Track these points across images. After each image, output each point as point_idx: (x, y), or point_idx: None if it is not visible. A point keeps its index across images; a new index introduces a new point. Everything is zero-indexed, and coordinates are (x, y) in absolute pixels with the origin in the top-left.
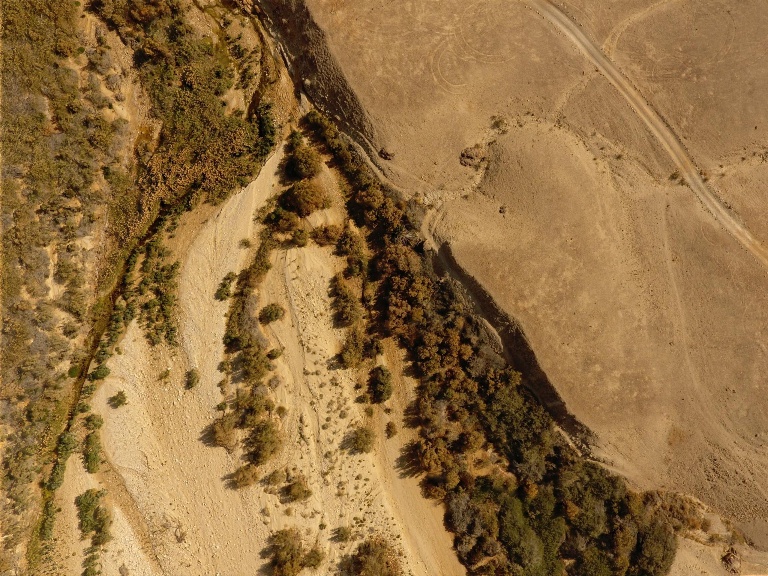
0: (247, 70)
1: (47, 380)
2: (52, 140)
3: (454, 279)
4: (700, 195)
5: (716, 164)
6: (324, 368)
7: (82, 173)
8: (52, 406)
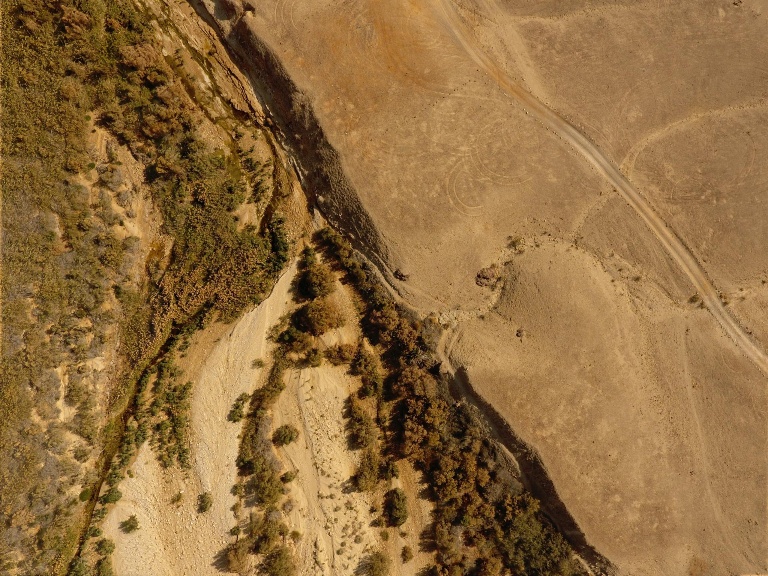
0: (259, 183)
1: (58, 506)
2: (63, 259)
3: (471, 404)
4: (720, 319)
5: (736, 287)
6: (339, 491)
7: (93, 293)
8: (63, 532)
